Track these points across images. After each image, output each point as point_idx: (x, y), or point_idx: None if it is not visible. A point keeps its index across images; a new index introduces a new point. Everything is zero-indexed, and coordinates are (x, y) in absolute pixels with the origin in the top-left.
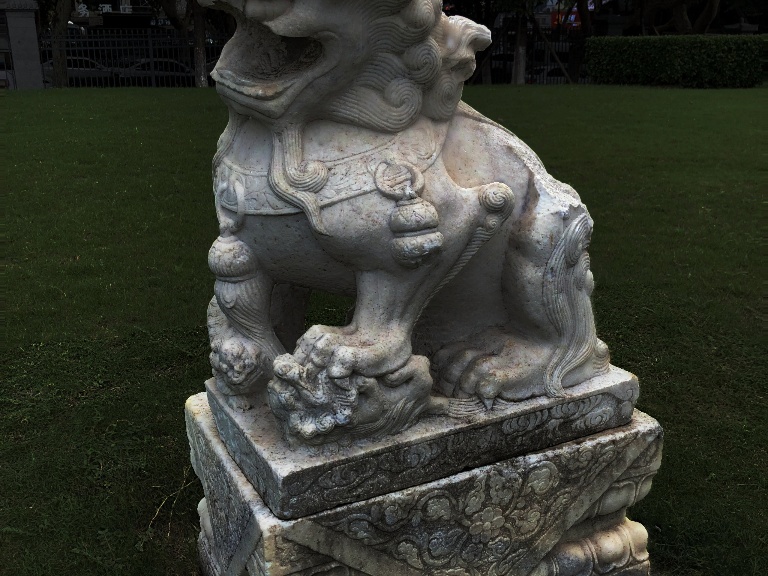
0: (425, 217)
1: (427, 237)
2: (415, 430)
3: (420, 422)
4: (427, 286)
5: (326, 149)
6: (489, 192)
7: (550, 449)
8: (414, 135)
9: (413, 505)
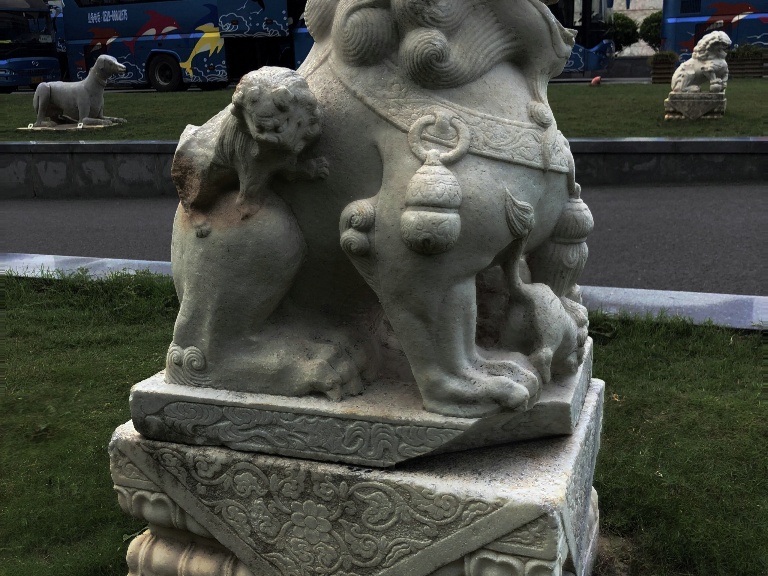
0: None
1: None
2: None
3: None
4: None
5: None
6: None
7: None
8: None
9: None
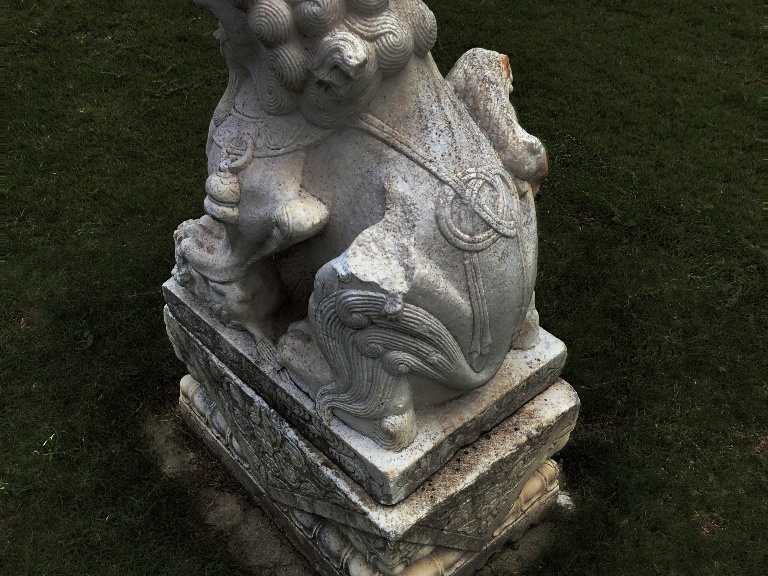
0: (212, 189)
1: (211, 205)
2: (232, 333)
3: (243, 333)
4: (243, 244)
5: (242, 99)
6: (278, 207)
7: (307, 444)
8: (279, 124)
9: (222, 376)
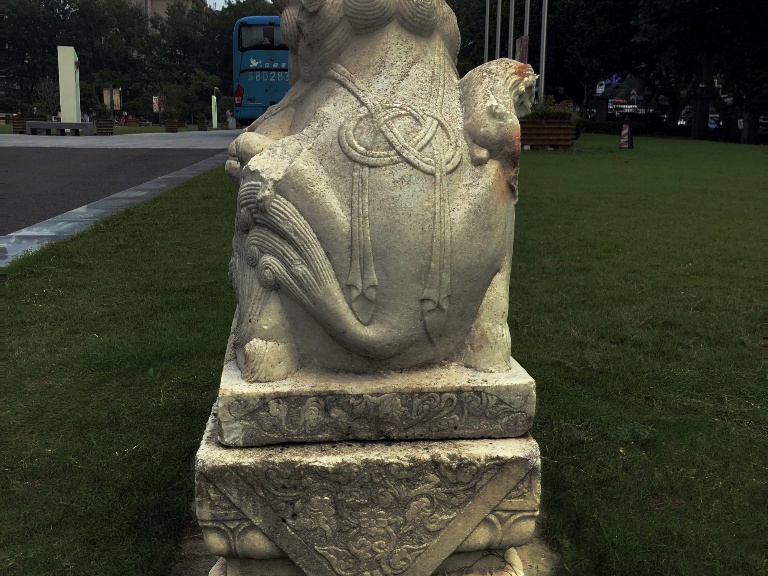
0: None
1: None
2: None
3: None
4: None
5: None
6: None
7: None
8: None
9: None
